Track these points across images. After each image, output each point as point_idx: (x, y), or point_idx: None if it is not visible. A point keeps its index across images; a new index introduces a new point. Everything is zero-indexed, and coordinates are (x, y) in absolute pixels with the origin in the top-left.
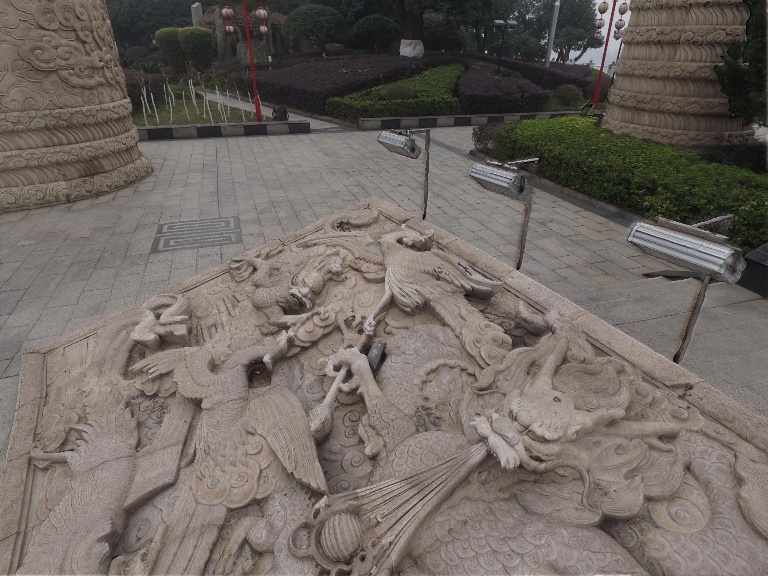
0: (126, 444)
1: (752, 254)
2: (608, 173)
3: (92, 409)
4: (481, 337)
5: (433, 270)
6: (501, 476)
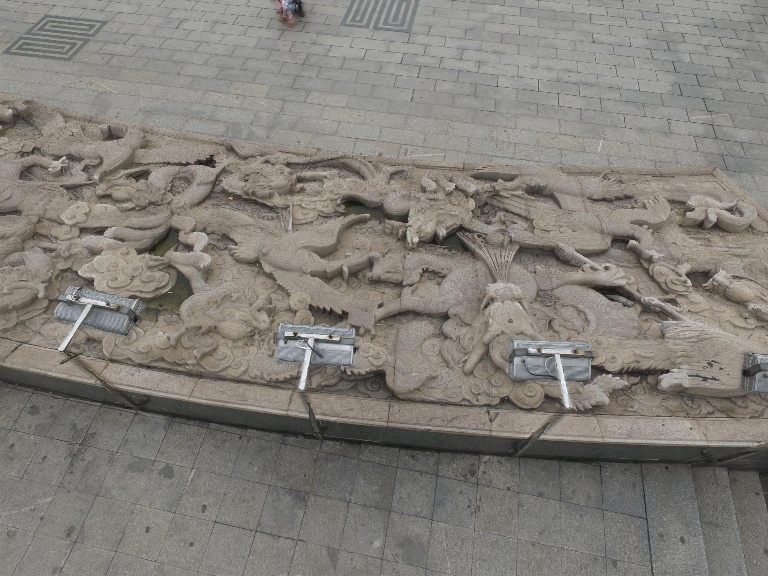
0: (593, 193)
1: None
2: None
3: (631, 186)
4: (602, 346)
5: (716, 360)
6: None
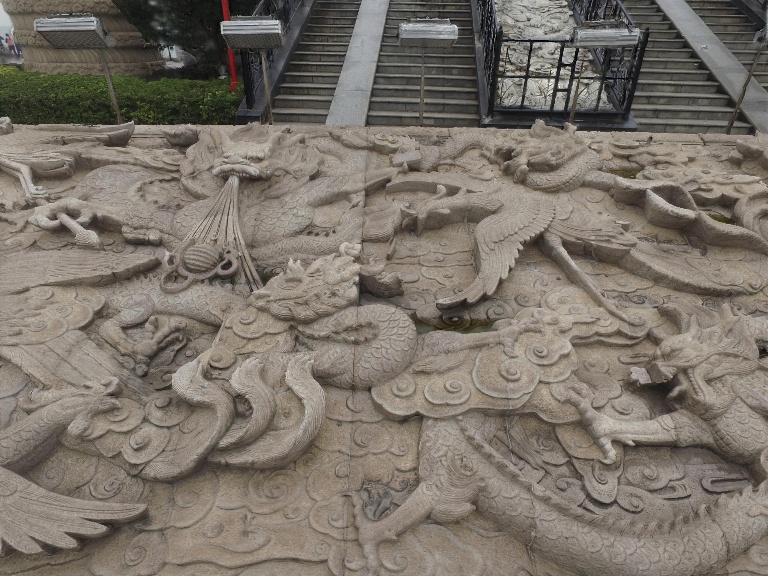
0: None
1: (238, 112)
2: (81, 103)
3: None
4: None
5: (52, 138)
6: (253, 190)
